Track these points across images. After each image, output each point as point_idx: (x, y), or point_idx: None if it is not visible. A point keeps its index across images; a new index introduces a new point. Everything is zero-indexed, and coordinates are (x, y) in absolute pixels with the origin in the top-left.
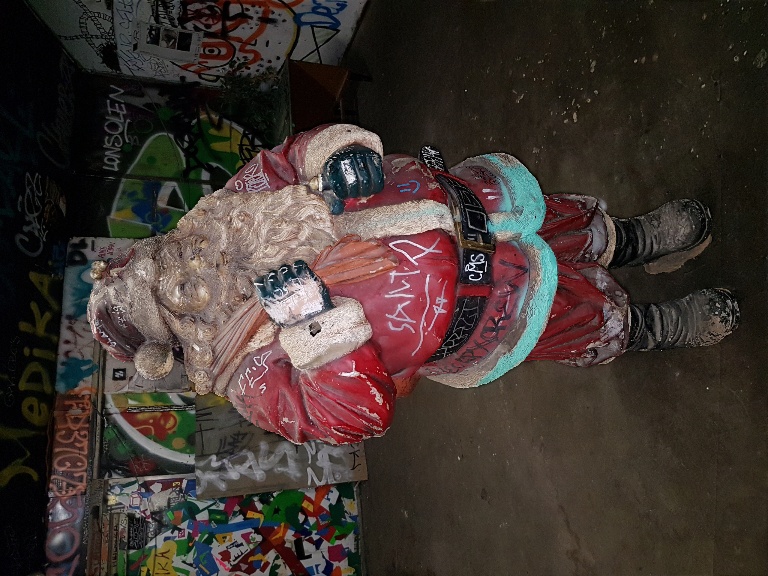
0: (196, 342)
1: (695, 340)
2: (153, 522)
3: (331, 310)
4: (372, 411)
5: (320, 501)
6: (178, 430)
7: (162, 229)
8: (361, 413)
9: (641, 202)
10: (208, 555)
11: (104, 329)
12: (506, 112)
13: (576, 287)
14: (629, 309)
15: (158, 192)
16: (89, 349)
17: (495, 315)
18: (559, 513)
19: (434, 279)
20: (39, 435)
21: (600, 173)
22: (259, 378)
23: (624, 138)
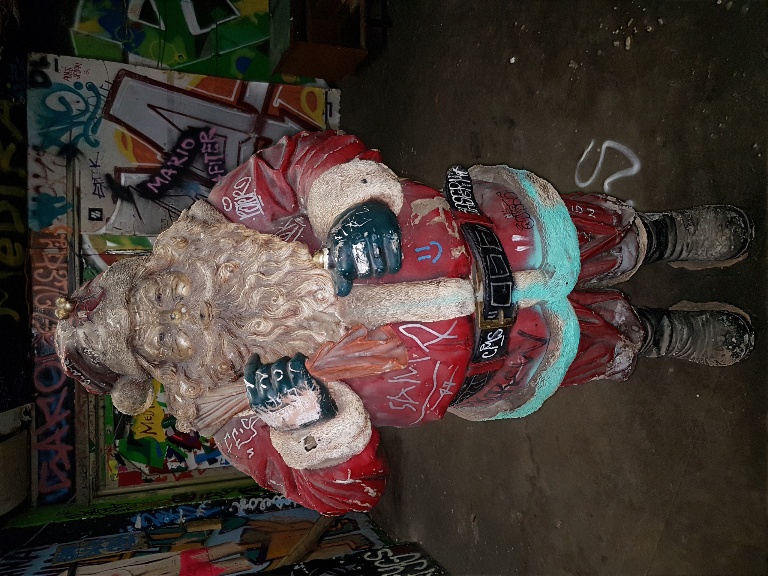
0: (178, 395)
1: (700, 360)
2: None
3: (329, 423)
4: (364, 502)
5: None
6: None
7: (135, 49)
8: (352, 502)
9: (680, 178)
10: None
11: (75, 367)
12: (547, 0)
13: (593, 331)
14: None
15: (128, 1)
16: (61, 185)
17: (503, 383)
18: (525, 441)
19: (444, 366)
20: (16, 275)
21: (642, 125)
22: (246, 442)
23: (680, 95)
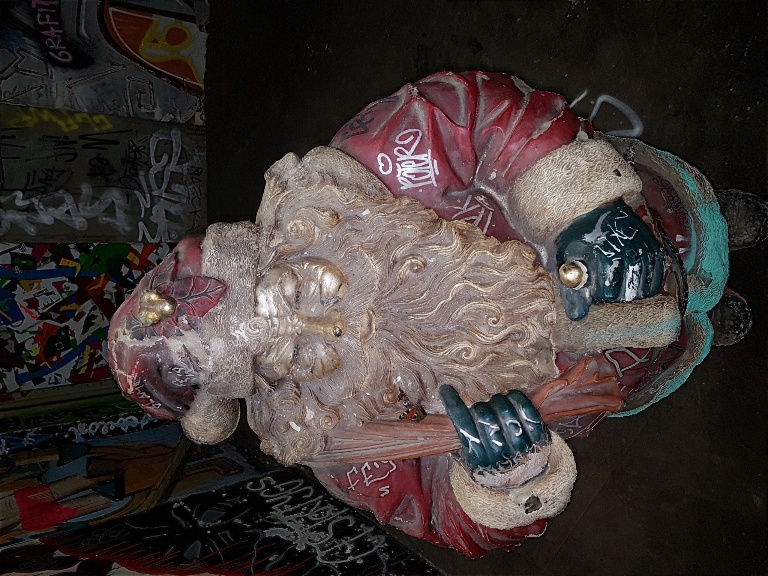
0: (300, 425)
1: None
2: None
3: (554, 479)
4: None
5: (148, 255)
6: None
7: None
8: None
9: (689, 153)
10: (10, 301)
11: (146, 389)
12: None
13: None
14: None
15: None
16: None
17: None
18: None
19: (627, 390)
20: None
21: (652, 87)
22: (382, 479)
23: (706, 66)
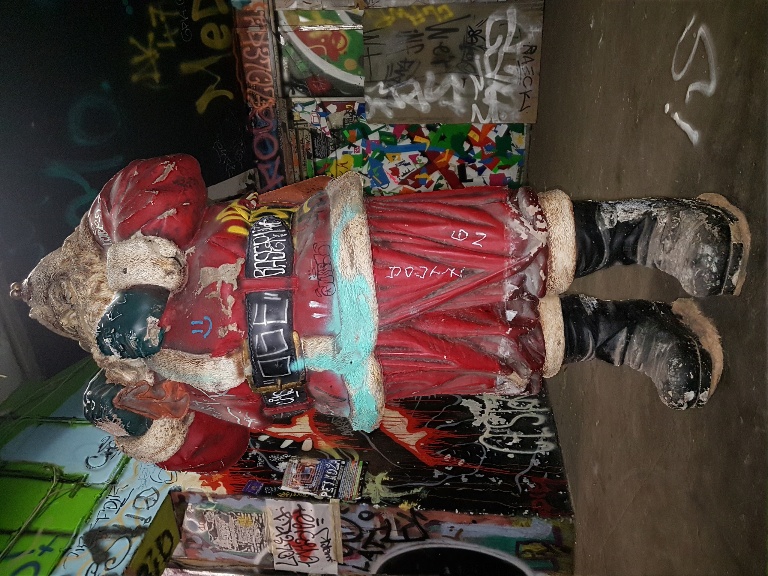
0: None
1: None
2: (332, 138)
3: (133, 442)
4: None
5: (487, 133)
6: (349, 51)
7: None
8: None
9: (735, 136)
10: (380, 169)
11: None
12: None
13: (450, 370)
14: (559, 357)
15: None
16: None
17: None
18: None
19: (234, 411)
20: (226, 57)
21: (730, 25)
22: None
23: (767, 2)
